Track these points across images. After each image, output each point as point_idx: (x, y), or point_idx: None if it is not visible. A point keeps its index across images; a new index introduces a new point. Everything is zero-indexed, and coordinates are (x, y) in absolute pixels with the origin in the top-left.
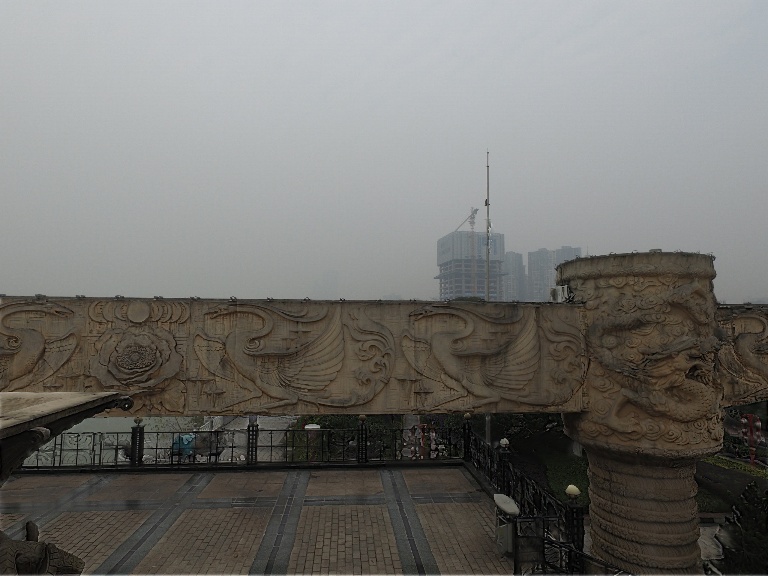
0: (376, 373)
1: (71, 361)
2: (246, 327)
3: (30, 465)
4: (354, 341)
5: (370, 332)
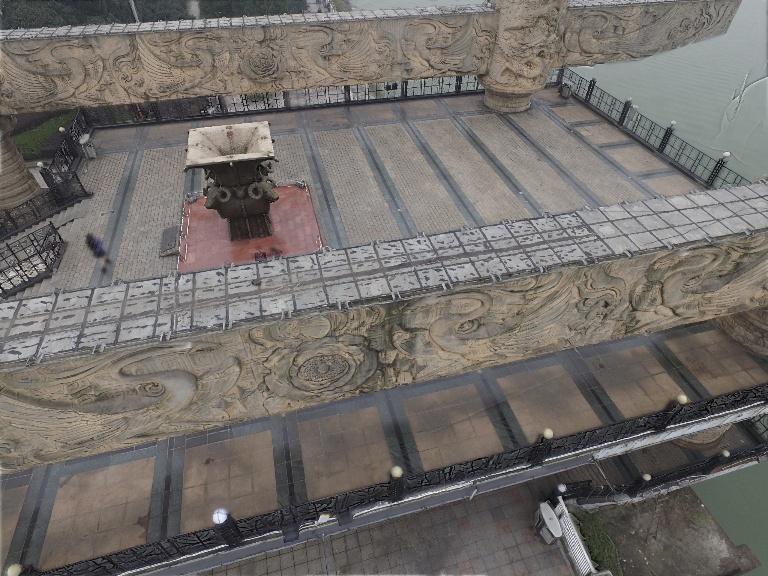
0: None
1: None
2: None
3: None
4: None
5: None
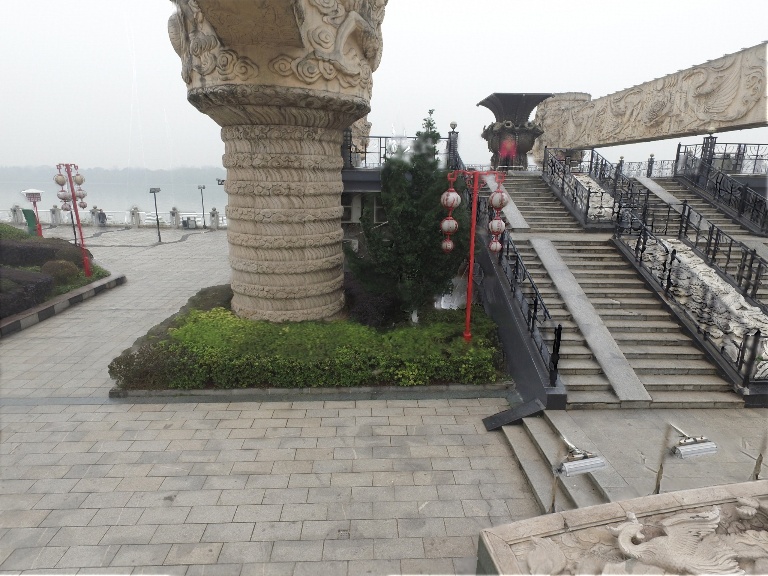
0: (753, 95)
1: None
2: (697, 81)
3: None
4: (745, 76)
5: (755, 67)
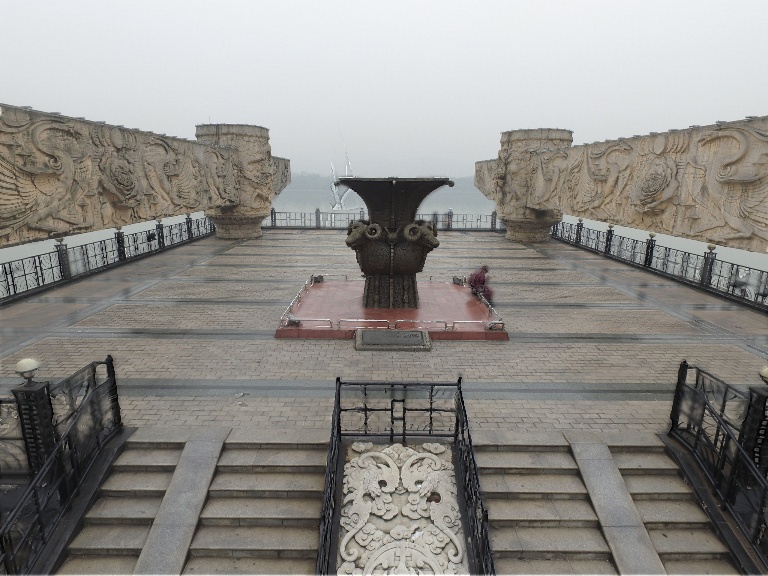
0: None
1: (627, 186)
2: (725, 152)
3: (653, 267)
4: None
5: None
